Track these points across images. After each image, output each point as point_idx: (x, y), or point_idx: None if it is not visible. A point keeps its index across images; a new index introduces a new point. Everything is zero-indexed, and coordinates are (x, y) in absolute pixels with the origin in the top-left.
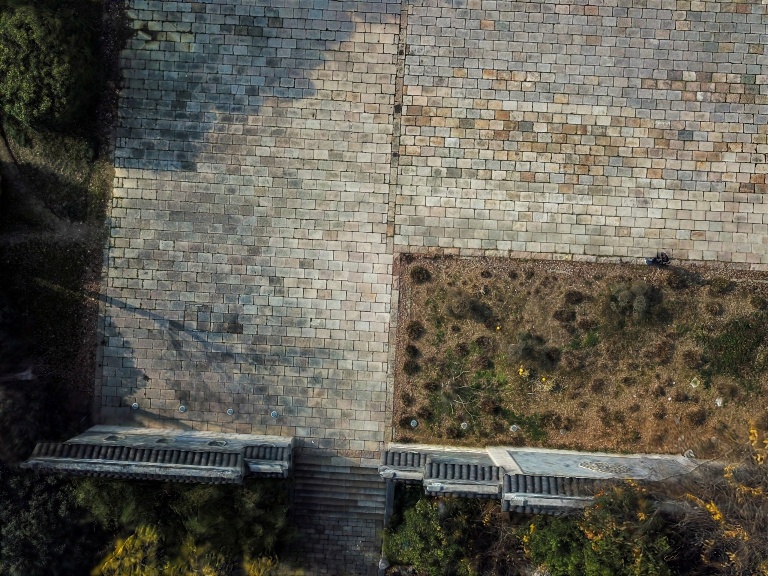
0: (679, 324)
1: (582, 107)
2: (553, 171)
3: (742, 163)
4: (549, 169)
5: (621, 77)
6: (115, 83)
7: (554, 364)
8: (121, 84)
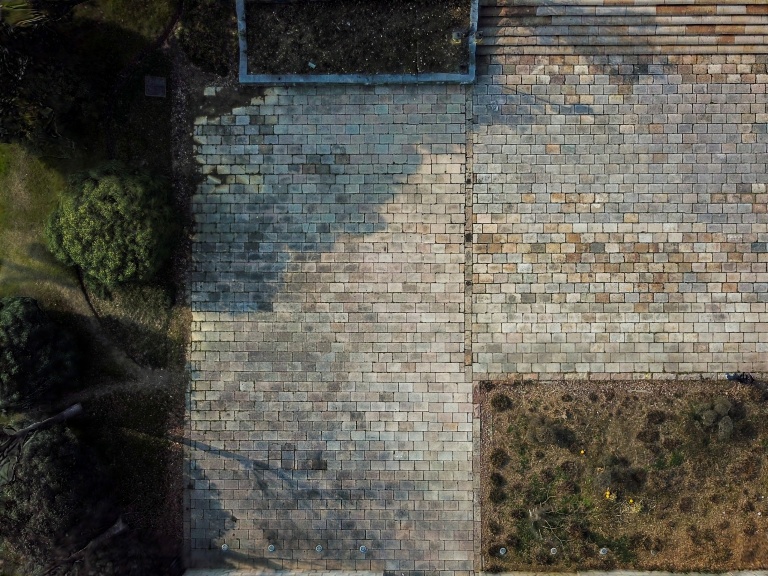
0: (764, 438)
1: (653, 225)
2: (627, 291)
3: None
4: (623, 289)
5: (690, 193)
6: (188, 229)
7: (641, 485)
8: (193, 229)
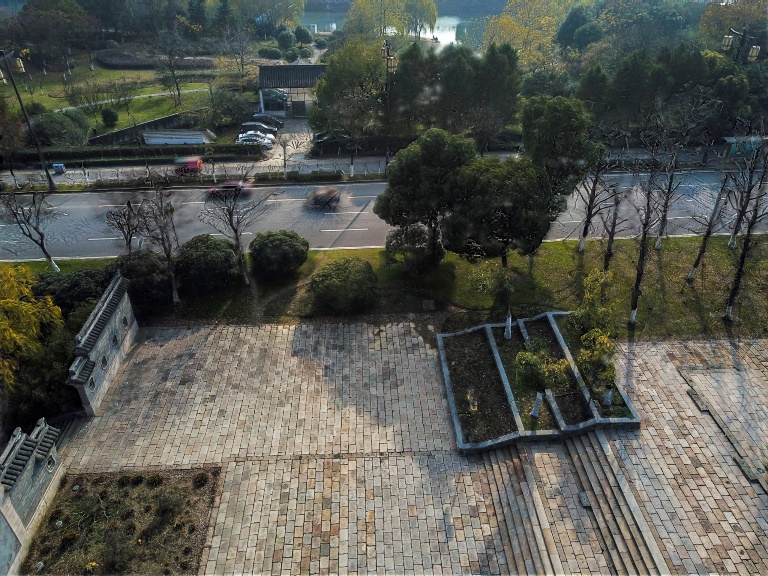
0: None
1: None
2: None
3: None
4: (285, 574)
5: None
6: (346, 322)
7: None
8: (346, 324)
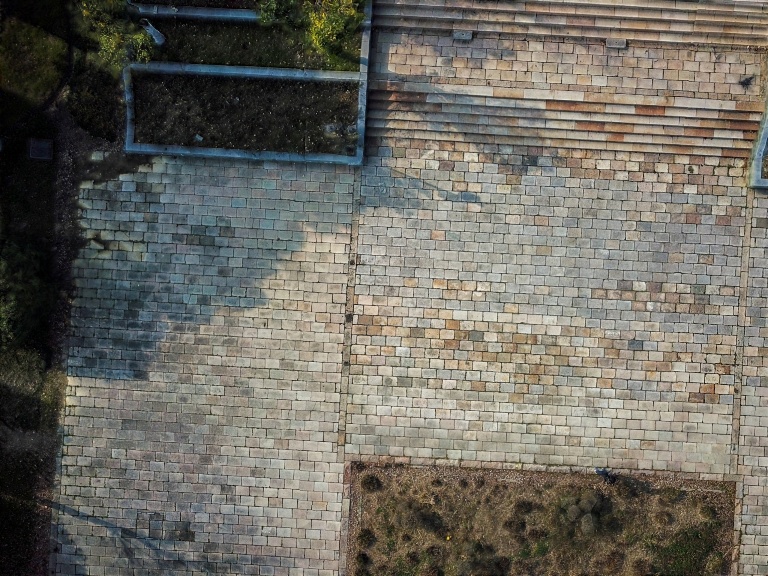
0: (628, 534)
1: (532, 317)
2: (503, 380)
3: (692, 373)
4: (499, 378)
5: (571, 287)
6: (68, 293)
7: (504, 574)
8: (74, 293)
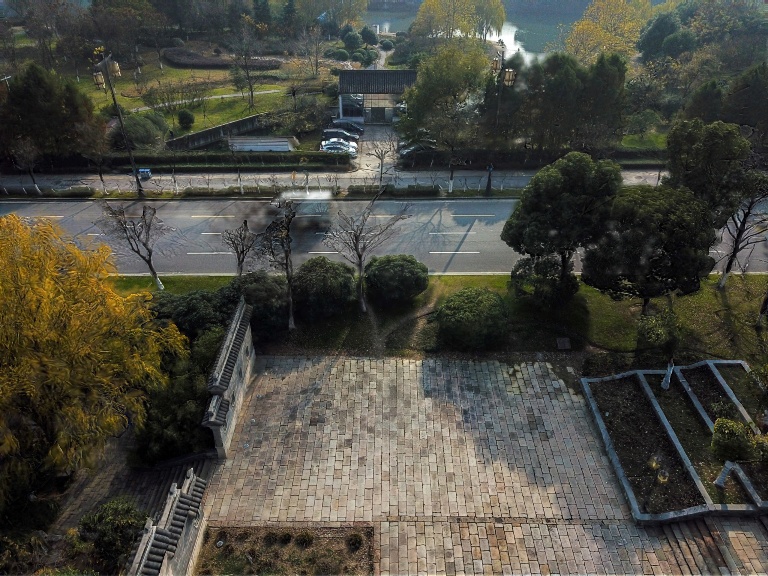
0: None
1: None
2: None
3: None
4: None
5: None
6: (476, 359)
7: None
8: (476, 361)
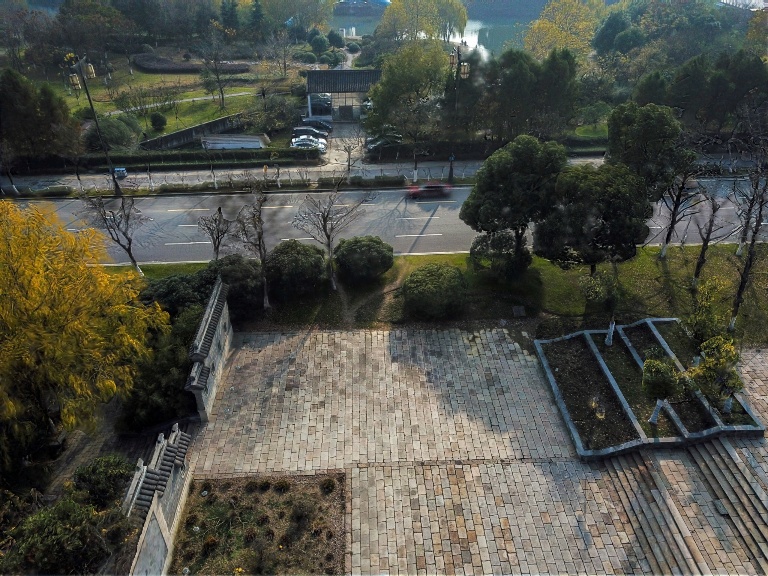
0: None
1: None
2: None
3: None
4: None
5: None
6: (439, 328)
7: None
8: (439, 330)
